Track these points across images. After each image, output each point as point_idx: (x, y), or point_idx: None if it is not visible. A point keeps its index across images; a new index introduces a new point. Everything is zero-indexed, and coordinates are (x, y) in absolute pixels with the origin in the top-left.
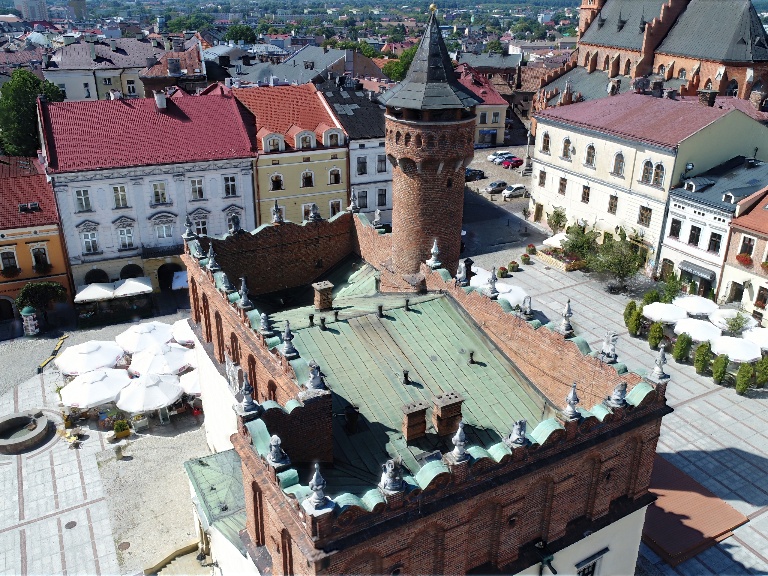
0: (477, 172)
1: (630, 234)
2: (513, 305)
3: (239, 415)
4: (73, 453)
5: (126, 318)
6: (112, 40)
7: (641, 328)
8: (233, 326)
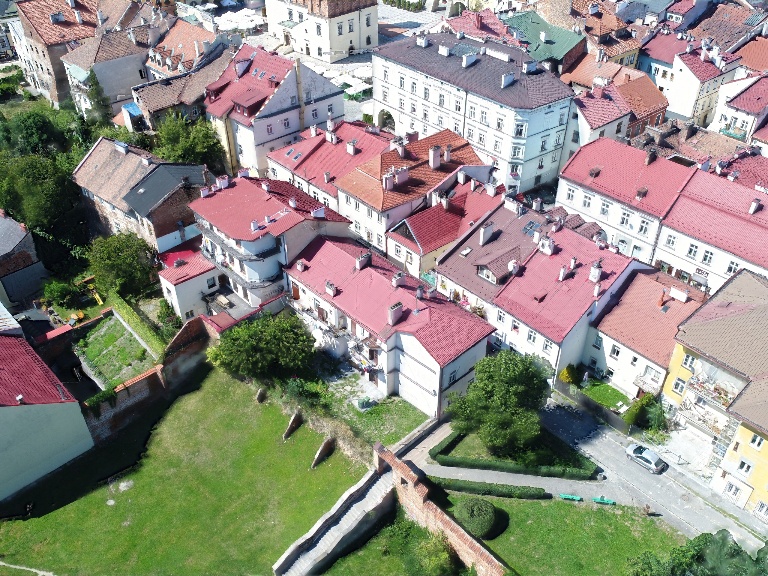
0: None
1: None
2: None
3: None
4: None
5: None
6: None
7: (388, 1)
8: None
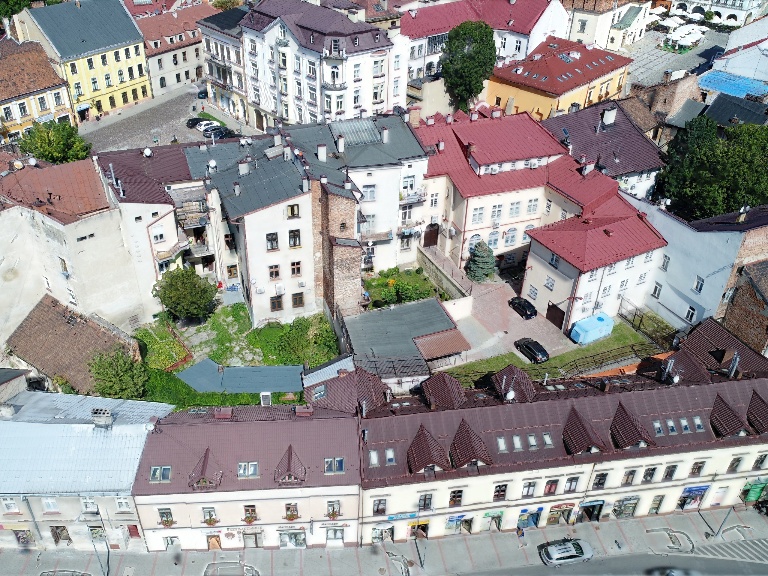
0: None
1: None
2: None
3: None
4: None
5: None
6: (340, 5)
7: None
8: None
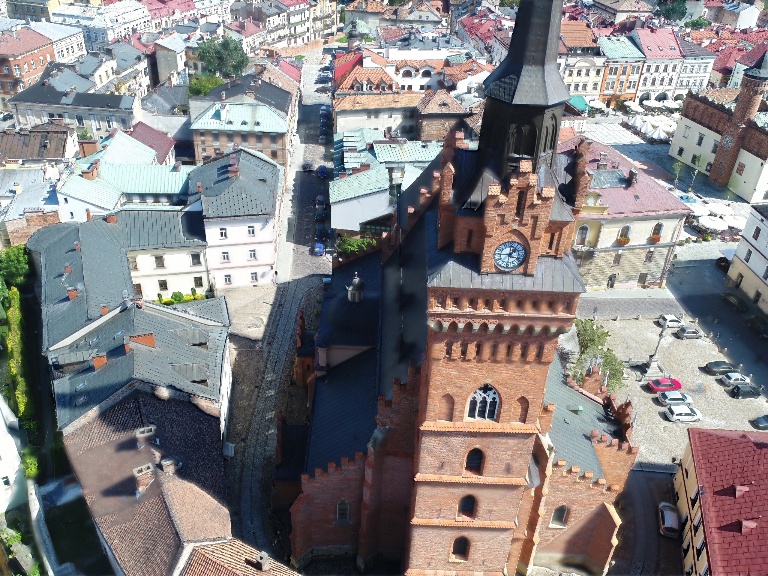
0: (717, 362)
1: None
2: None
3: None
4: None
5: None
6: None
7: None
8: None
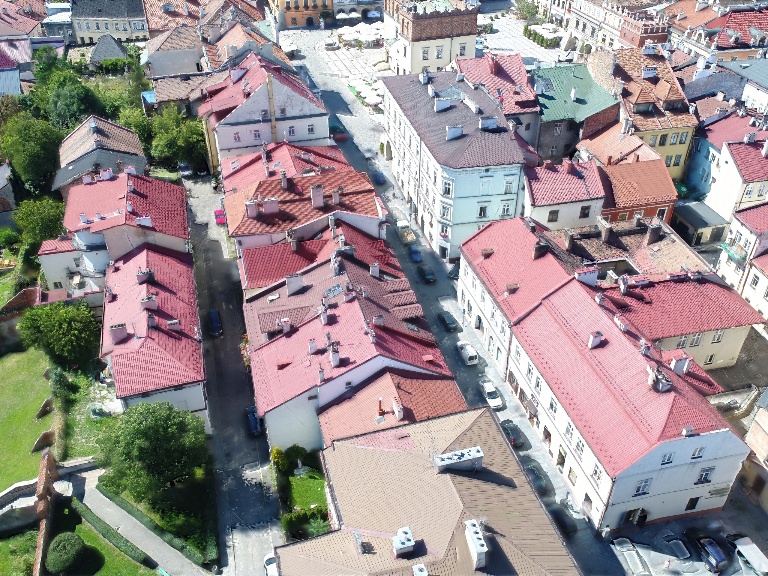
0: None
1: (544, 5)
2: (485, 24)
3: (402, 6)
4: (348, 51)
5: (352, 26)
6: None
7: None
8: (398, 1)
